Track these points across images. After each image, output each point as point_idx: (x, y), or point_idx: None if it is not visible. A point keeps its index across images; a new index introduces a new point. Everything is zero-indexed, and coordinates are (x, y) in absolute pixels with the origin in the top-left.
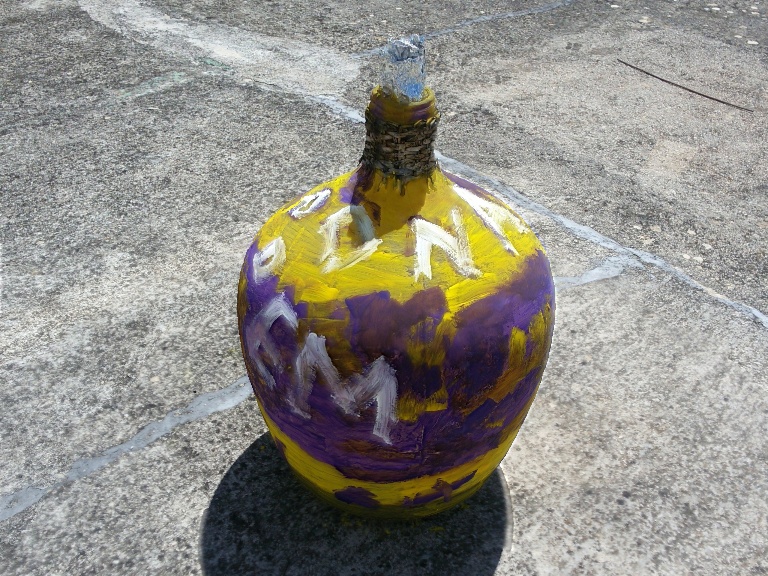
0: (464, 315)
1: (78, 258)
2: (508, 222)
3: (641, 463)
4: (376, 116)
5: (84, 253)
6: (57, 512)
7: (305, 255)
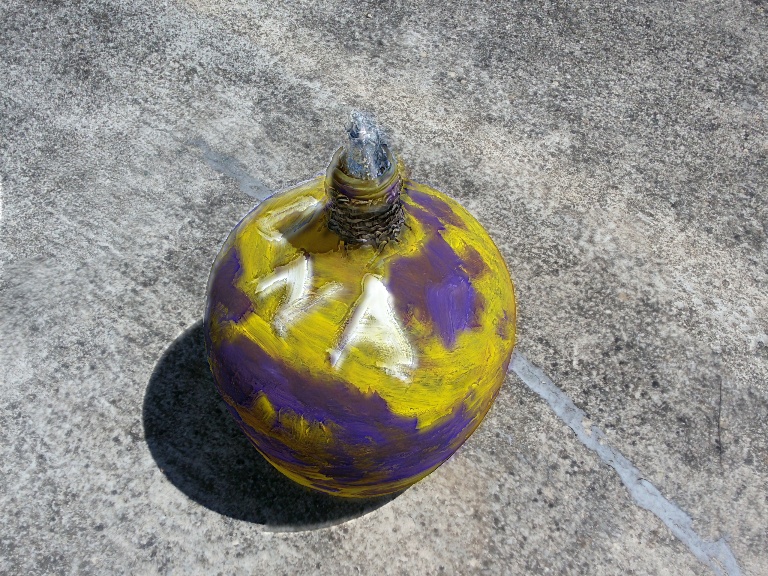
0: (238, 337)
1: (546, 115)
2: (376, 346)
3: None
4: None
5: (555, 116)
6: None
7: None
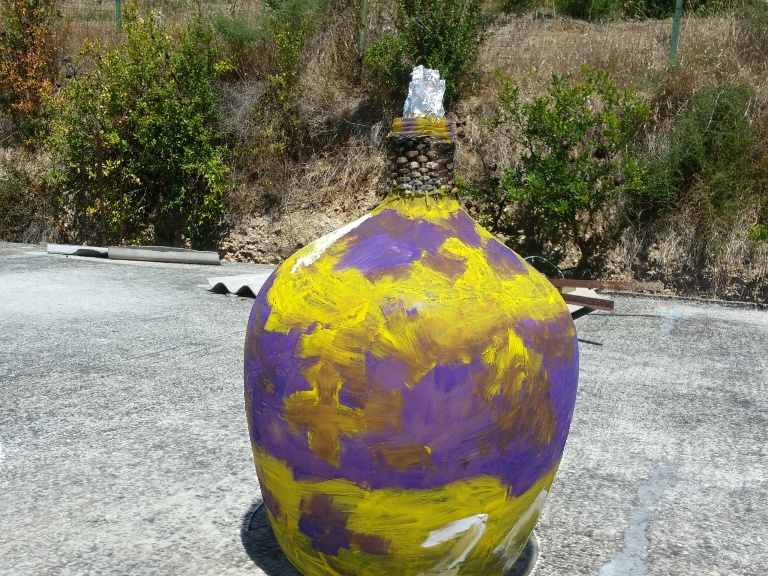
0: None
1: None
2: None
3: None
4: None
5: None
6: None
7: None
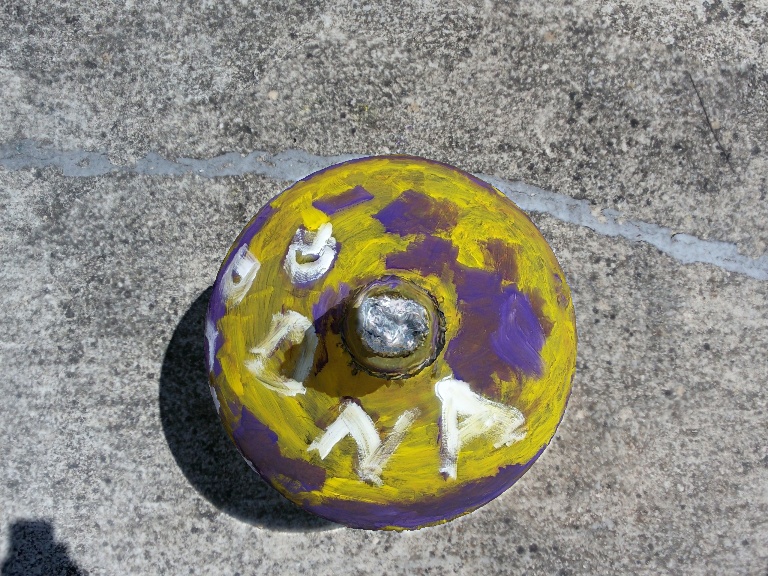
0: (333, 502)
1: None
2: (486, 435)
3: (582, 534)
4: (345, 318)
5: None
6: (109, 199)
7: (248, 325)
